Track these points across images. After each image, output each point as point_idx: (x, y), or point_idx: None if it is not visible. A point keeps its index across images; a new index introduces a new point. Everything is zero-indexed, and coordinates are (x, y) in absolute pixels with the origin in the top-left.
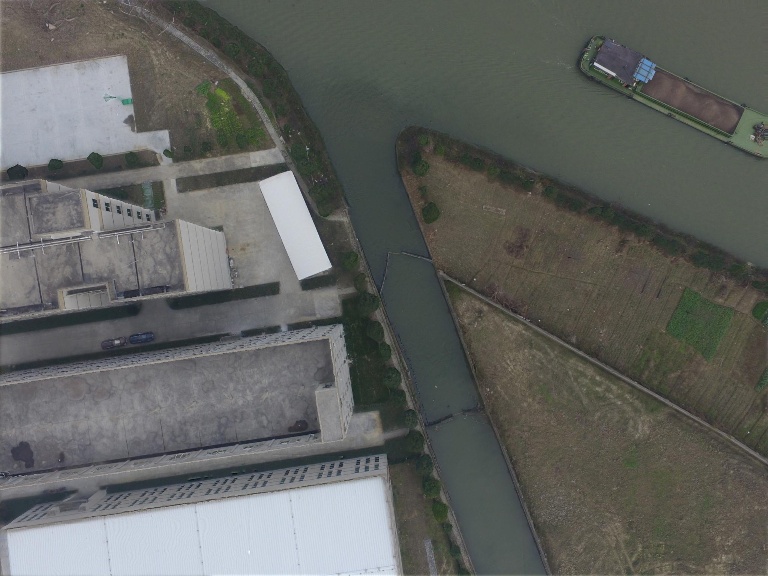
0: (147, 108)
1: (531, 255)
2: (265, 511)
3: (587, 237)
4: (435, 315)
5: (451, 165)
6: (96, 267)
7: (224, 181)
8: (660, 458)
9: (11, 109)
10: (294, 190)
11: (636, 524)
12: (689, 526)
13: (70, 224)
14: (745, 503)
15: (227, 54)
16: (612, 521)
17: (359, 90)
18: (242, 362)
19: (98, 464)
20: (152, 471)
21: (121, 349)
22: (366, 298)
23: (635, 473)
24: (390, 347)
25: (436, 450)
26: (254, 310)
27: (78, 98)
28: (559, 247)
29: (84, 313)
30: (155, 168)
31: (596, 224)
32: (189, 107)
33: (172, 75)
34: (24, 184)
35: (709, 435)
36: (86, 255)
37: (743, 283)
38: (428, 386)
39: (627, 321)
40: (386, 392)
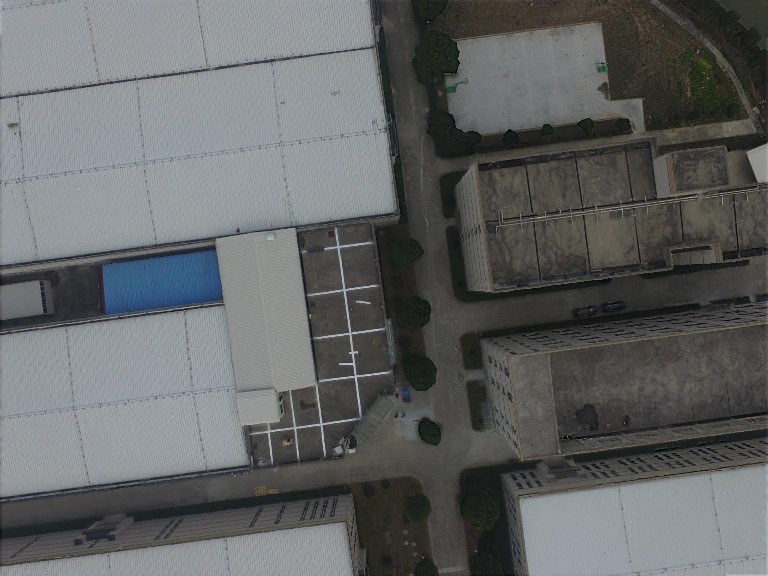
0: (622, 76)
1: None
2: None
3: None
4: None
5: None
6: (696, 227)
7: None
8: None
9: (484, 74)
10: None
11: None
12: None
13: (711, 181)
14: None
15: (725, 22)
16: None
17: None
18: None
19: (665, 427)
20: (617, 441)
21: (590, 318)
22: None
23: None
24: None
25: None
26: (723, 281)
27: (552, 64)
28: None
29: None
30: (627, 136)
31: None
32: (672, 75)
33: (657, 43)
34: (629, 142)
35: None
36: (687, 215)
37: None
38: None
39: None
40: None
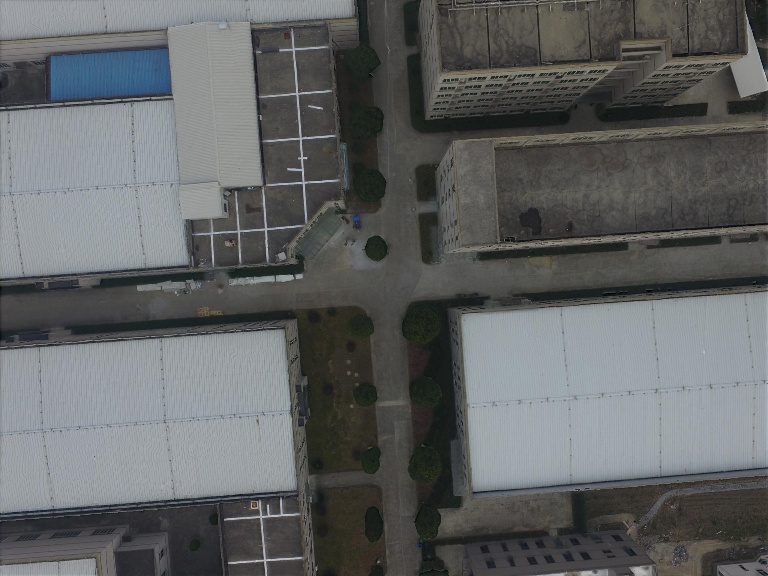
0: None
1: None
2: (721, 313)
3: None
4: None
5: None
6: (648, 27)
7: None
8: None
9: None
10: None
11: None
12: None
13: None
14: None
15: None
16: None
17: None
18: (756, 145)
19: None
20: (565, 283)
21: None
22: None
23: None
24: None
25: None
26: None
27: None
28: None
29: (516, 116)
30: None
31: None
32: None
33: None
34: None
35: None
36: (640, 13)
37: None
38: None
39: None
40: None
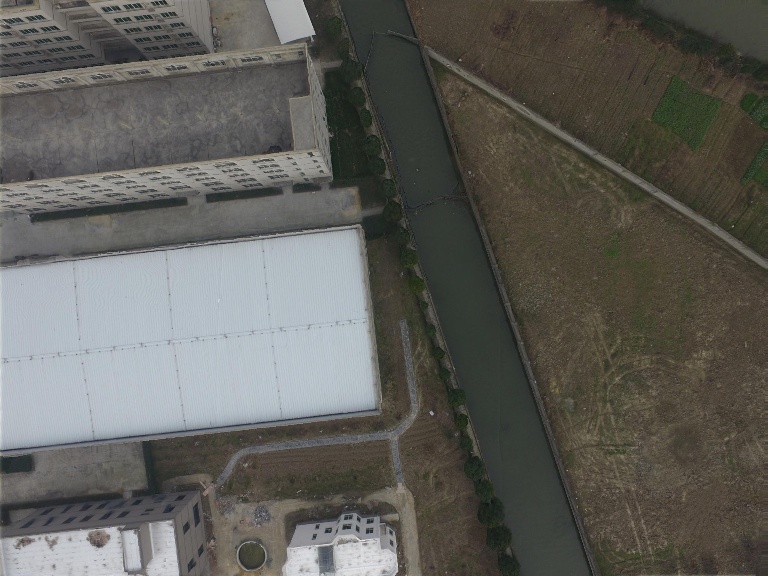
0: None
1: (518, 38)
2: (237, 261)
3: (575, 20)
4: (419, 102)
5: None
6: None
7: None
8: (642, 248)
9: None
10: None
11: (616, 315)
12: (670, 319)
13: None
14: (727, 298)
15: None
16: (591, 311)
17: None
18: (218, 84)
19: None
20: (126, 241)
21: None
22: (348, 60)
23: (616, 262)
24: (372, 122)
25: (415, 229)
26: None
27: None
28: (546, 30)
29: None
30: None
31: (584, 6)
32: None
33: None
34: None
35: (693, 228)
36: None
37: (732, 72)
38: (409, 168)
39: (613, 107)
40: (366, 167)
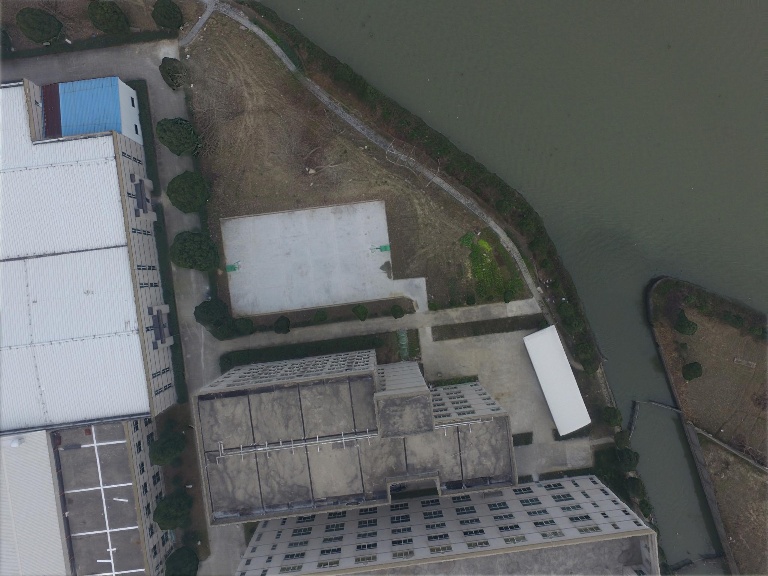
0: (405, 255)
1: None
2: None
3: None
4: (674, 460)
5: (706, 319)
6: (420, 457)
7: (481, 331)
8: None
9: (265, 252)
10: (557, 345)
11: None
12: None
13: (417, 427)
14: None
15: (500, 210)
16: None
17: (613, 239)
18: None
19: None
20: None
21: None
22: (631, 457)
23: None
24: None
25: None
26: None
27: (334, 243)
28: None
29: None
30: (410, 315)
31: None
32: (452, 258)
33: (436, 225)
34: None
35: None
36: (411, 445)
37: None
38: (671, 534)
39: None
40: None
